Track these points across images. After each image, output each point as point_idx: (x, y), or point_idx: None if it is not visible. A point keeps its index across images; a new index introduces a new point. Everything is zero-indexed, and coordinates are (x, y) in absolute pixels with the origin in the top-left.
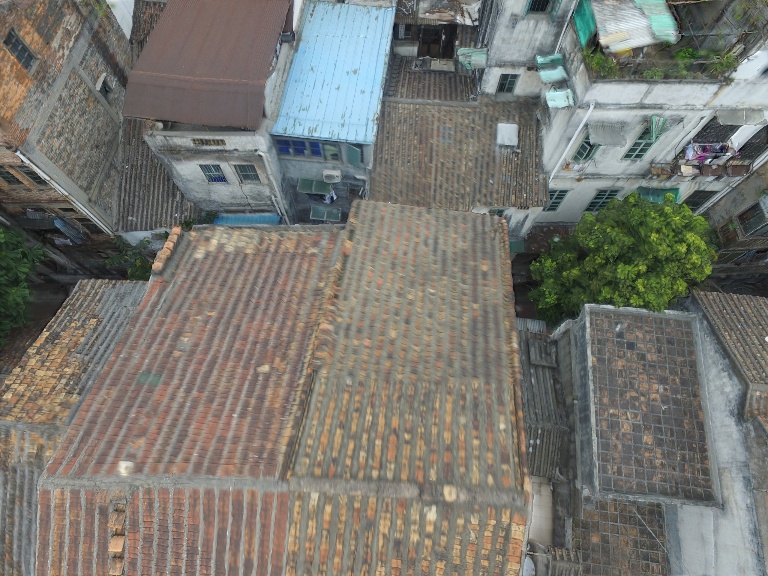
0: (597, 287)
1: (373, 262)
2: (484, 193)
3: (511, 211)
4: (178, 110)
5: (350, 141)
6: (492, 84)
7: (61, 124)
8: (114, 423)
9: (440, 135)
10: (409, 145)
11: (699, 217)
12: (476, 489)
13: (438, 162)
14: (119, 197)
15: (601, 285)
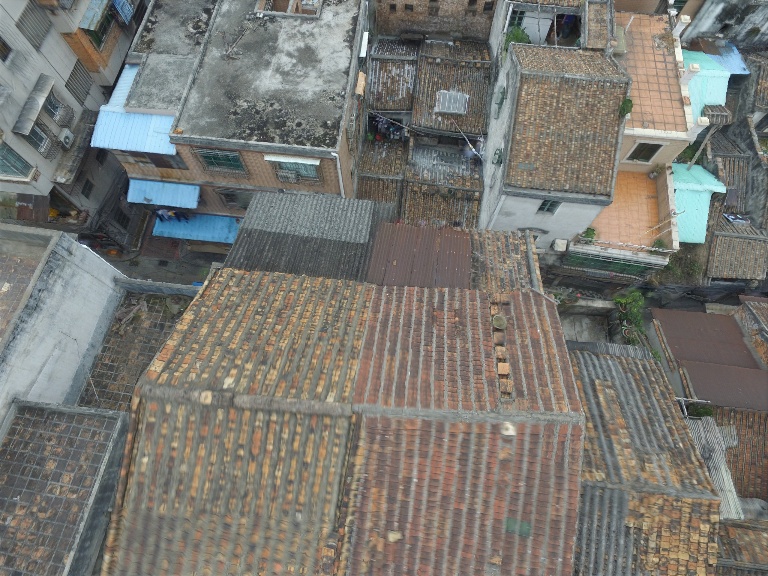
0: None
1: None
2: None
3: None
4: None
5: None
6: None
7: None
8: (537, 476)
9: None
10: None
11: None
12: (182, 400)
13: None
14: None
15: None
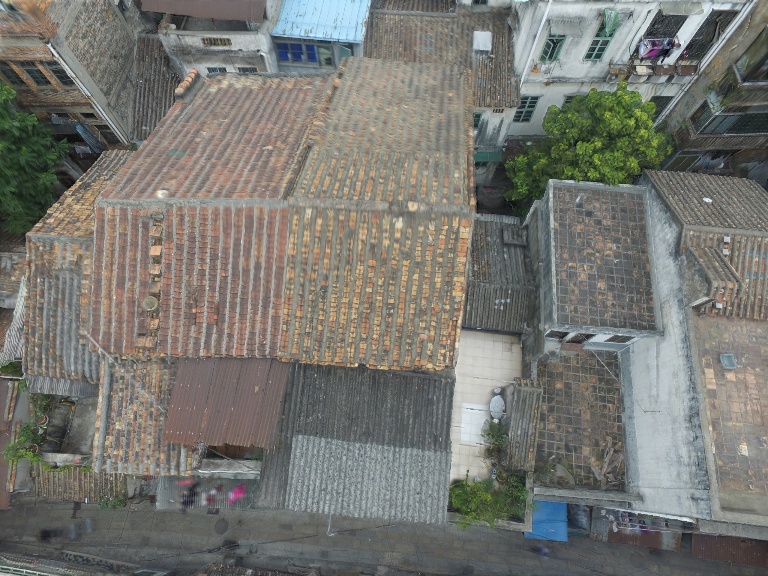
0: (561, 169)
1: (358, 91)
2: None
3: (487, 115)
4: (190, 6)
5: (341, 40)
6: None
7: (85, 27)
8: (151, 174)
9: (422, 43)
10: (395, 52)
11: None
12: (433, 204)
13: None
14: (134, 109)
15: (564, 167)
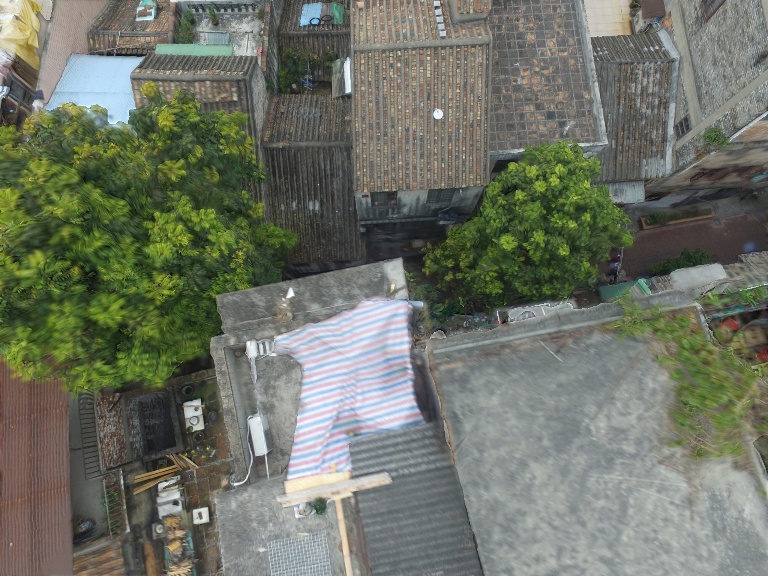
0: None
1: None
2: None
3: None
4: None
5: None
6: None
7: None
8: None
9: None
10: None
11: (511, 246)
12: None
13: None
14: None
15: None
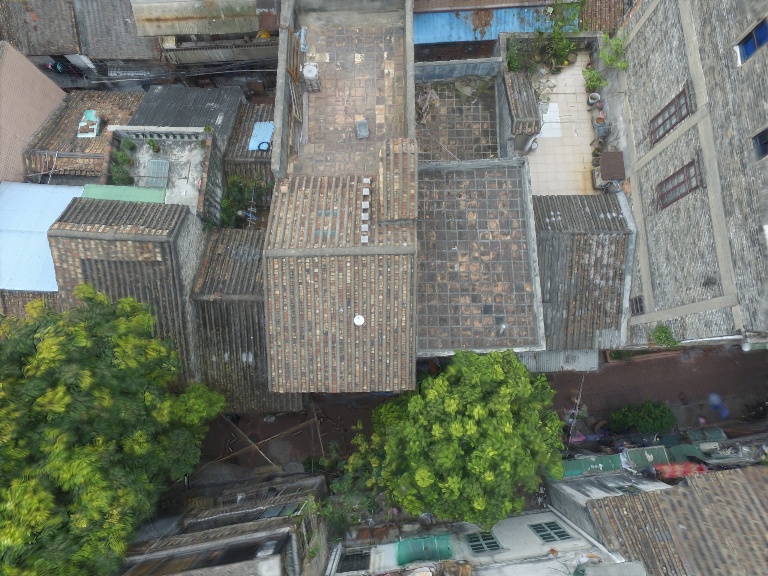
0: None
1: None
2: (684, 507)
3: None
4: None
5: None
6: None
7: None
8: None
9: None
10: None
11: (426, 484)
12: None
13: None
14: None
15: None
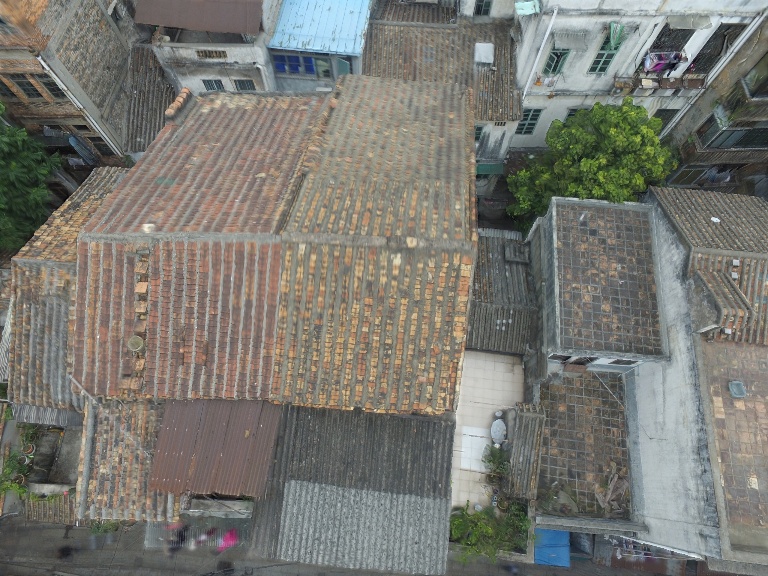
0: (564, 185)
1: (355, 112)
2: None
3: (489, 128)
4: (184, 18)
5: (340, 53)
6: (469, 5)
7: (77, 39)
8: (137, 205)
9: (423, 54)
10: (394, 64)
11: None
12: (433, 239)
13: (421, 79)
14: (128, 120)
15: (568, 183)
